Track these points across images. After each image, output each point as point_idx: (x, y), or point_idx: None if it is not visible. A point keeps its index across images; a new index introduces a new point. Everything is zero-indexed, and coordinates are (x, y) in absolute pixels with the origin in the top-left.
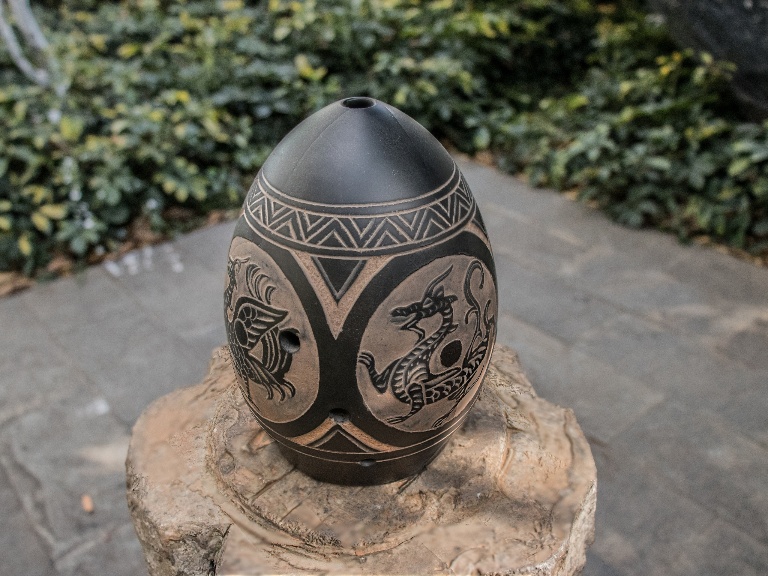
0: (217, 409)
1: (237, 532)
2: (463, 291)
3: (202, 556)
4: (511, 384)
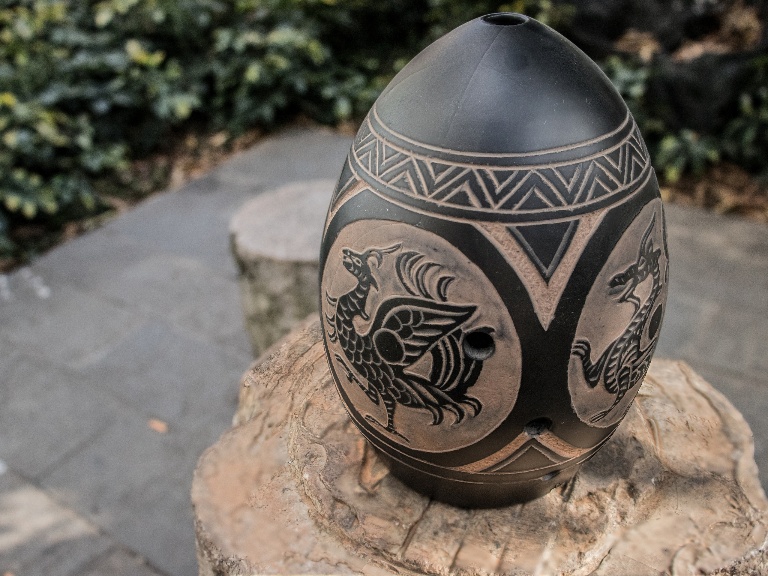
0: (289, 448)
1: None
2: (662, 242)
3: None
4: None
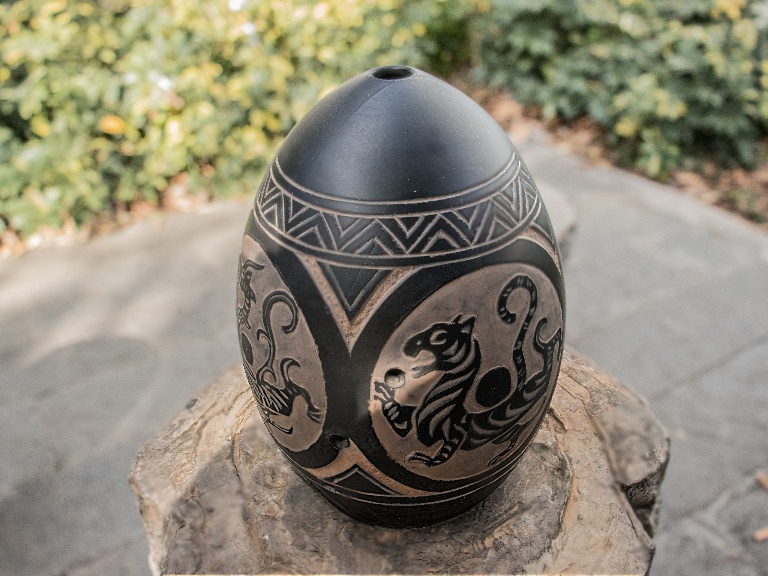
0: None
1: None
2: (263, 304)
3: None
4: None
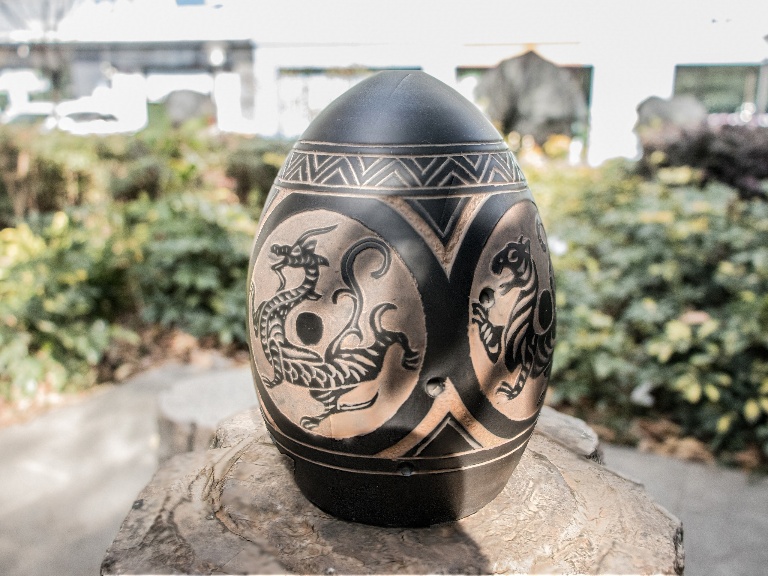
0: None
1: (222, 451)
2: (341, 261)
3: None
4: (584, 572)
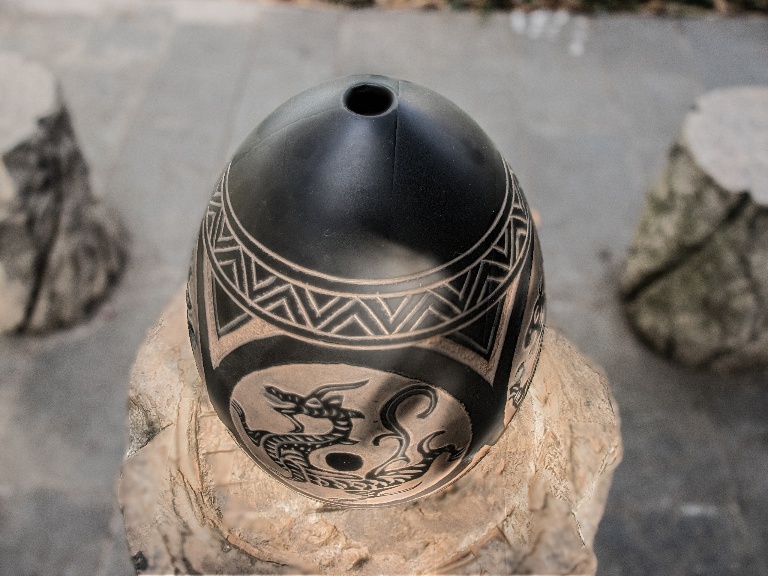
0: None
1: (169, 435)
2: (379, 412)
3: (144, 430)
4: (564, 477)
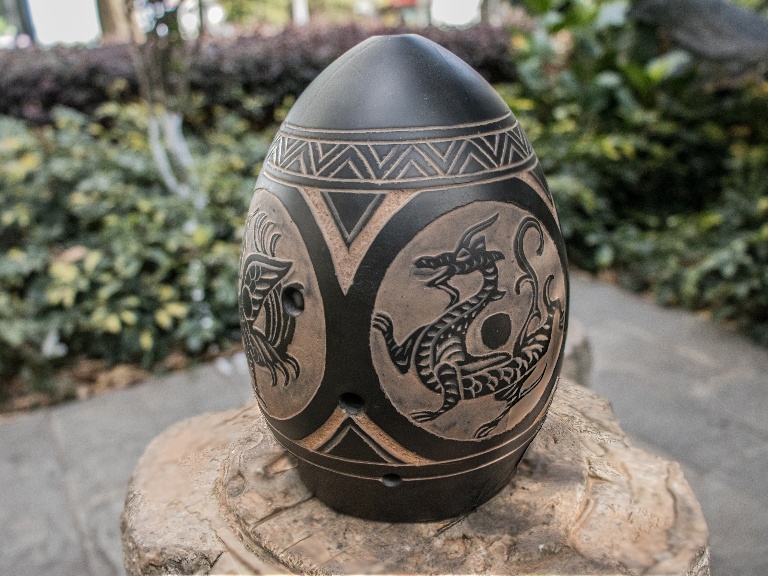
0: (243, 434)
1: (228, 561)
2: (513, 250)
3: None
4: (599, 431)
